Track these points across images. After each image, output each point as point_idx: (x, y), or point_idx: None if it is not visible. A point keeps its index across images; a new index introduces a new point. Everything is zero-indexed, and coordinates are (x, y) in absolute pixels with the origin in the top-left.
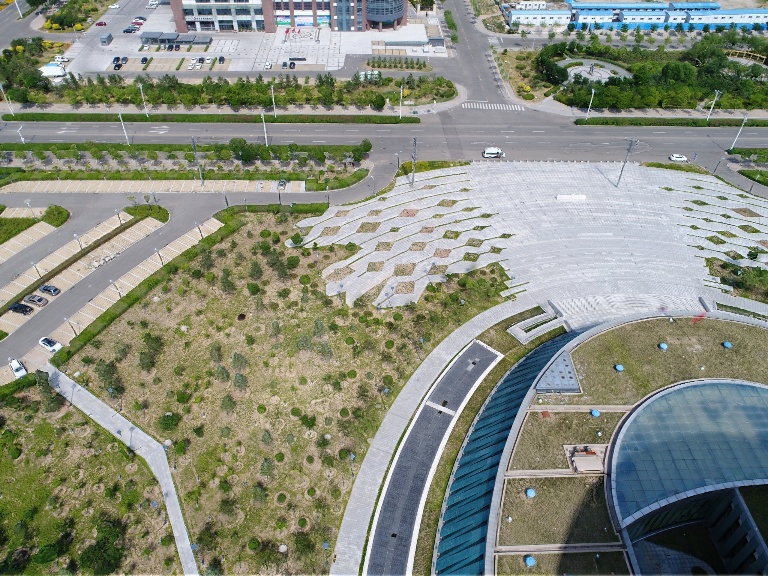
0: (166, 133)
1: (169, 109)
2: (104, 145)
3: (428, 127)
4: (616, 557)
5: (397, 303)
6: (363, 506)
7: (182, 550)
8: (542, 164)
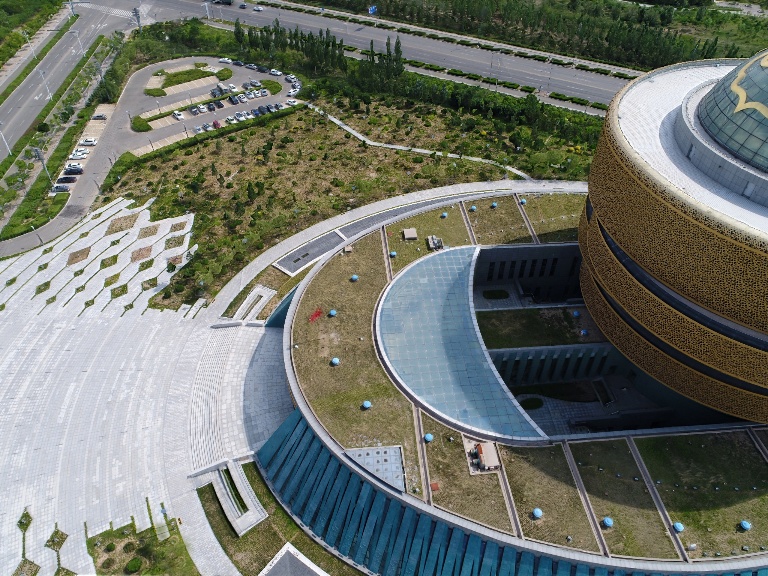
0: None
1: None
2: None
3: None
4: (575, 450)
5: None
6: None
7: None
8: None
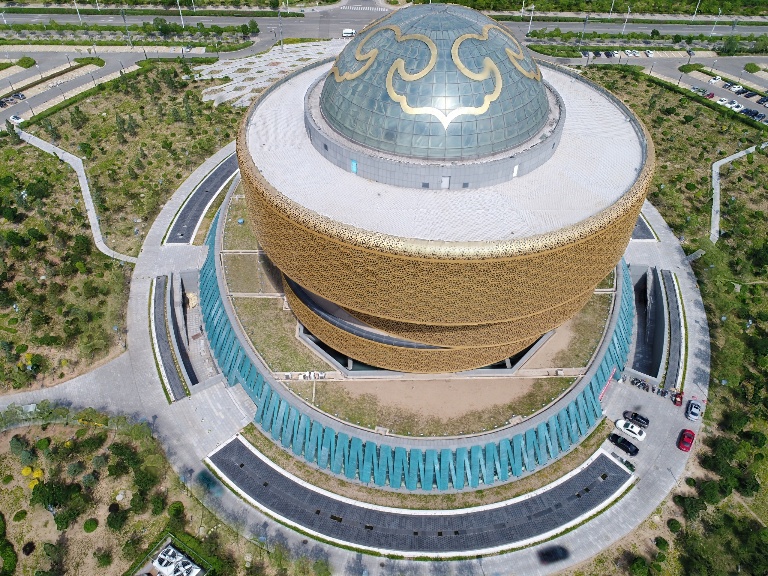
0: (112, 21)
1: (116, 7)
2: (64, 26)
3: (309, 20)
4: None
5: (247, 105)
6: (193, 182)
7: (85, 194)
8: None
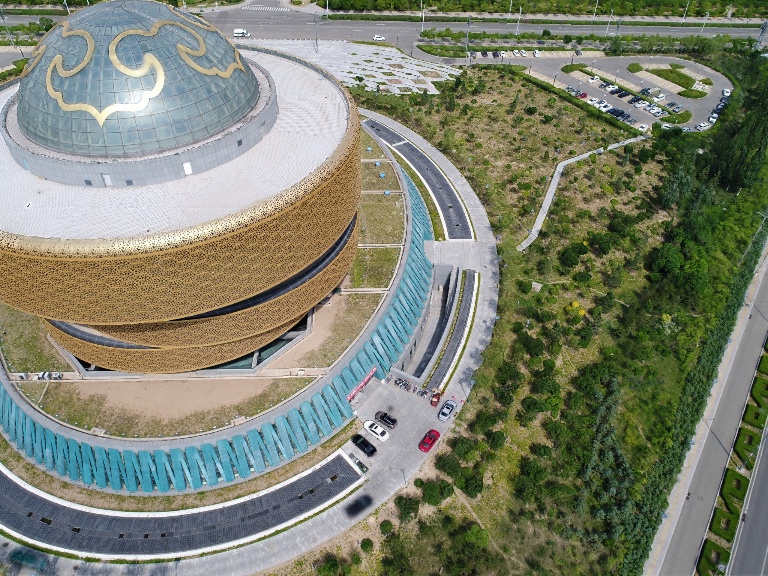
0: (5, 21)
1: (14, 7)
2: None
3: (206, 20)
4: None
5: None
6: None
7: None
8: (274, 41)
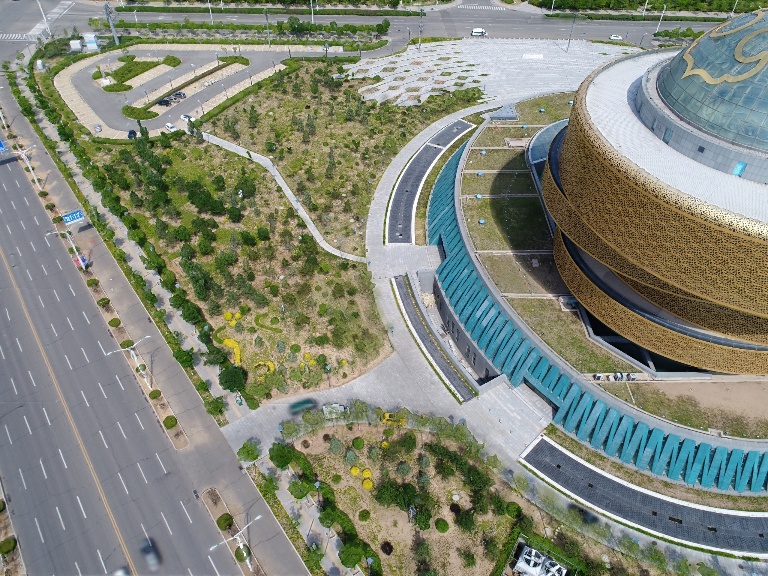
0: (237, 20)
1: (237, 6)
2: None
3: (432, 19)
4: (527, 174)
5: (409, 104)
6: (389, 181)
7: (288, 194)
8: (515, 40)
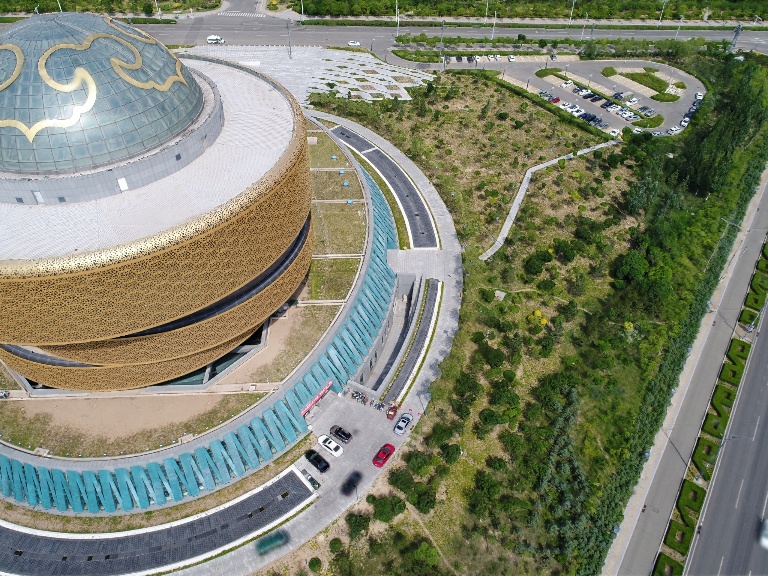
0: None
1: None
2: None
3: (180, 26)
4: None
5: None
6: None
7: None
8: (248, 47)
